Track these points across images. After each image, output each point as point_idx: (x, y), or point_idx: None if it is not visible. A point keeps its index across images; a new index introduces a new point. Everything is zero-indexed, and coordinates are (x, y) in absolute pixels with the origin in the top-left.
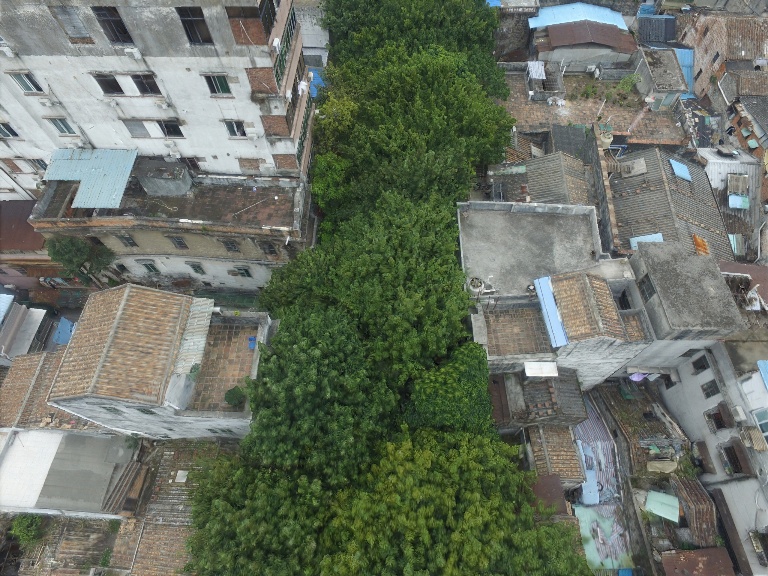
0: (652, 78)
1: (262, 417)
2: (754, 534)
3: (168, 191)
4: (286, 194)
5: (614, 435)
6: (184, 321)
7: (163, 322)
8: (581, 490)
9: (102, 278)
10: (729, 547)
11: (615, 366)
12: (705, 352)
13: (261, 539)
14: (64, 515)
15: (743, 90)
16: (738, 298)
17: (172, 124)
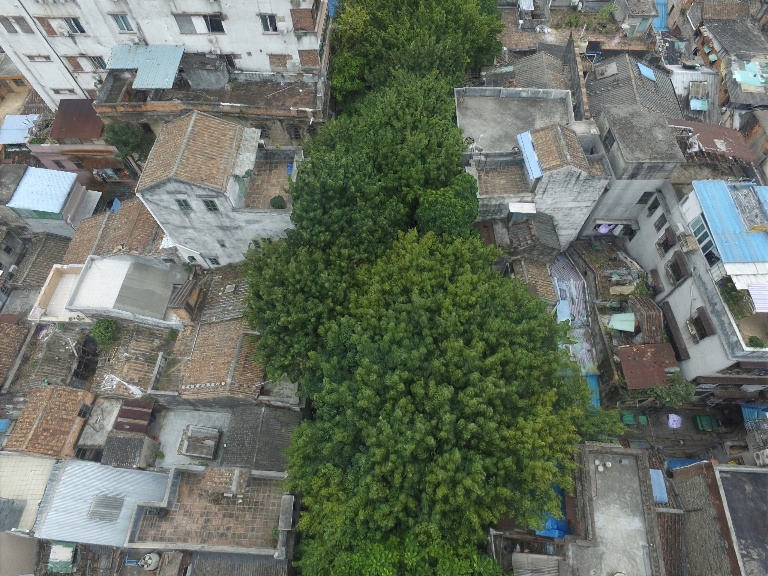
0: (627, 5)
1: (302, 201)
2: (690, 321)
3: (209, 84)
4: (309, 88)
5: (584, 275)
6: (238, 142)
7: (223, 140)
8: (556, 316)
9: None
10: (673, 343)
11: (584, 213)
12: (657, 194)
13: (303, 286)
14: (133, 324)
15: (706, 15)
16: (682, 144)
17: (216, 19)
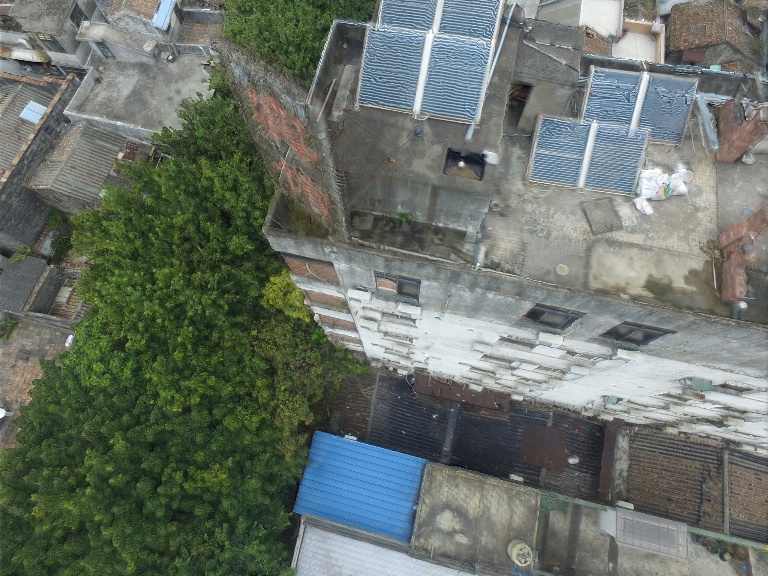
0: None
1: None
2: None
3: None
4: None
5: None
6: None
7: None
8: None
9: None
10: None
11: None
12: None
13: None
14: None
15: None
16: None
17: None
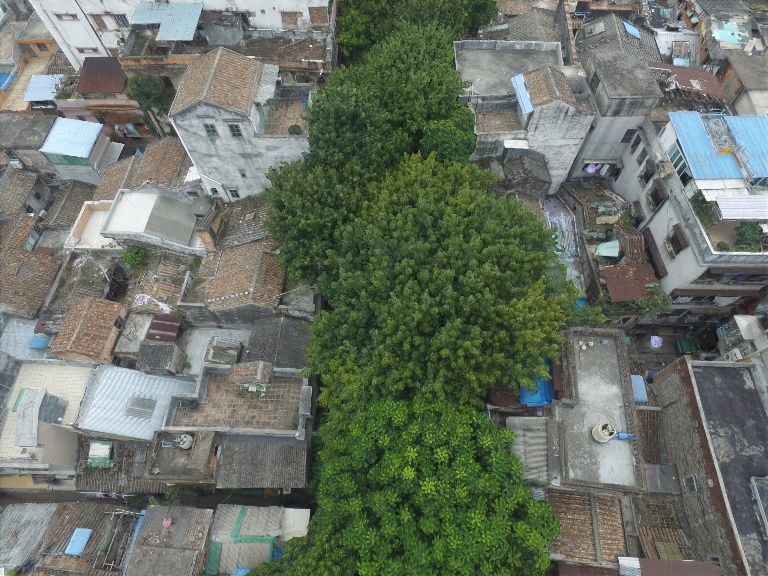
0: None
1: (319, 124)
2: (667, 239)
3: (225, 40)
4: (318, 44)
5: (574, 210)
6: (259, 75)
7: (245, 73)
8: None
9: (165, 128)
10: (653, 264)
11: (573, 151)
12: (638, 131)
13: (320, 197)
14: (160, 251)
15: None
16: None
17: None
